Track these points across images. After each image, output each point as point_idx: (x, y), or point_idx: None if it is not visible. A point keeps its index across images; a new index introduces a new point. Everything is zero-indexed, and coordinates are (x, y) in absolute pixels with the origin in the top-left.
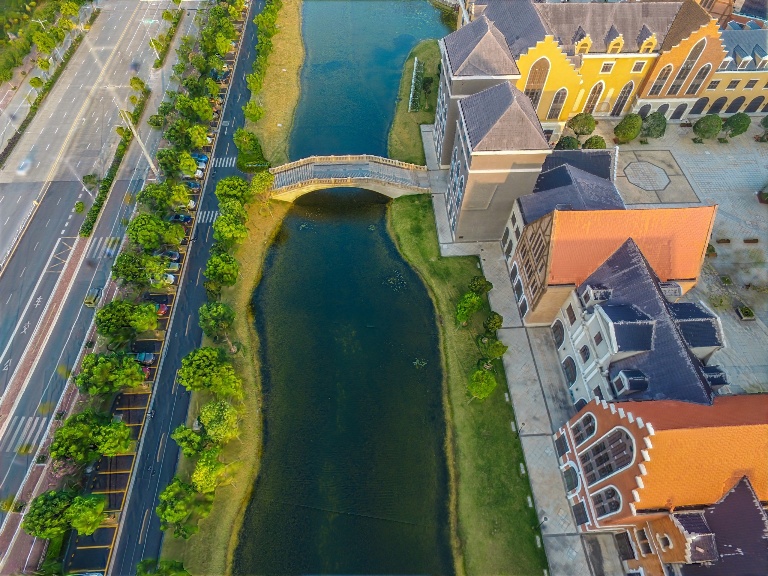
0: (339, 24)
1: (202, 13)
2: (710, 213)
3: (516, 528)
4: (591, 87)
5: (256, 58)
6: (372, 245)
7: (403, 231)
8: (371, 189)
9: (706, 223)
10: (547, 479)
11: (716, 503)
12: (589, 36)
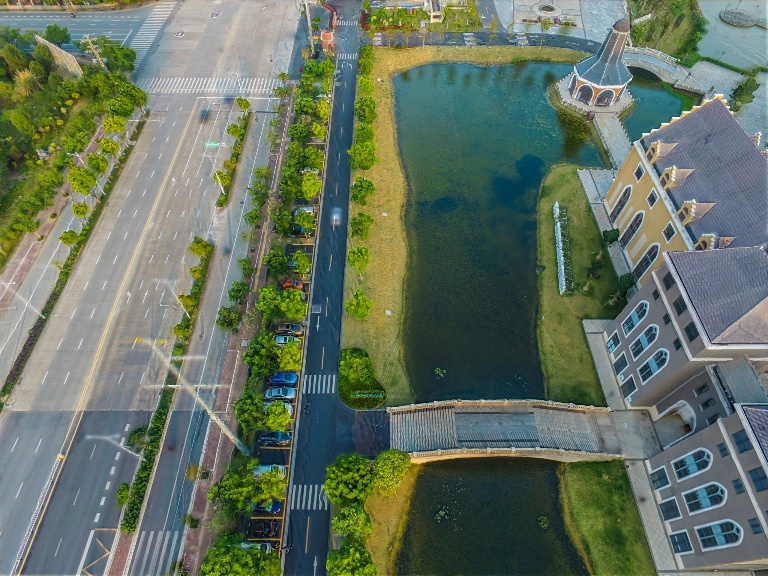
0: (443, 136)
1: (273, 118)
2: None
3: None
4: None
5: (347, 194)
6: (549, 559)
7: (593, 534)
8: (540, 457)
9: None
10: None
11: None
12: None
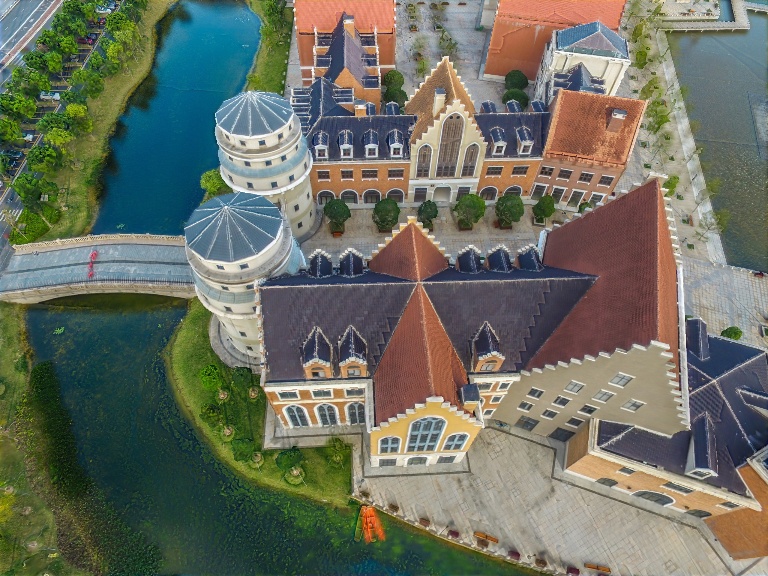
0: None
1: None
2: None
3: (272, 89)
4: None
5: None
6: (234, 6)
7: None
8: None
9: None
10: (296, 76)
11: (335, 28)
12: None
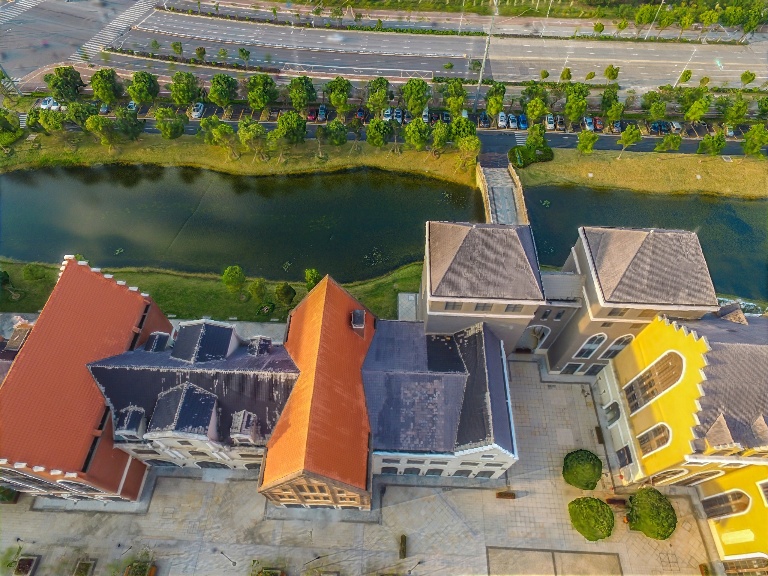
0: None
1: None
2: (299, 466)
3: None
4: (763, 551)
5: None
6: (423, 244)
7: None
8: None
9: (294, 467)
10: None
11: None
12: None
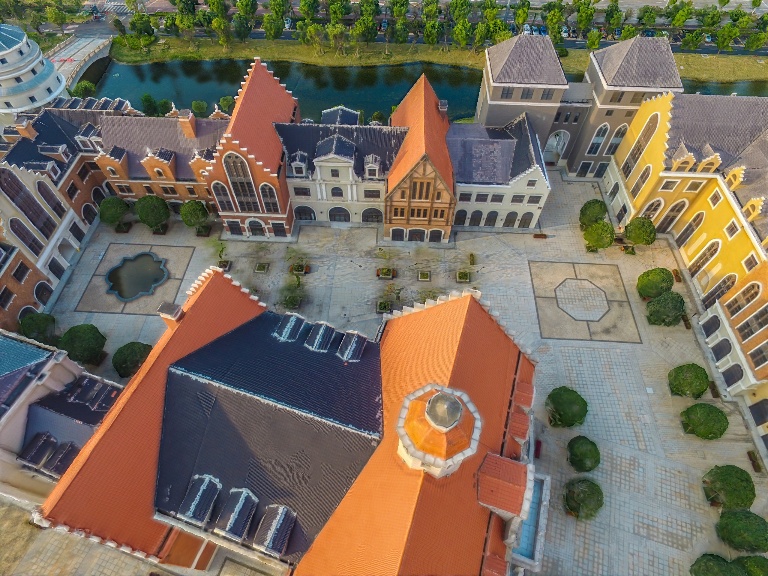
0: None
1: None
2: (421, 154)
3: None
4: (711, 239)
5: (693, 52)
6: (470, 108)
7: None
8: None
9: None
10: None
11: None
12: (758, 182)
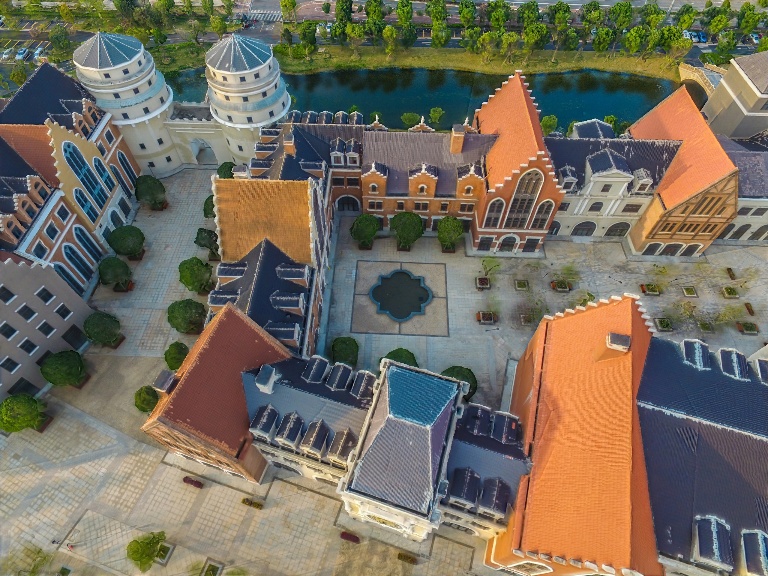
0: None
1: None
2: (729, 170)
3: None
4: None
5: None
6: None
7: None
8: None
9: (718, 175)
10: None
11: None
12: None
